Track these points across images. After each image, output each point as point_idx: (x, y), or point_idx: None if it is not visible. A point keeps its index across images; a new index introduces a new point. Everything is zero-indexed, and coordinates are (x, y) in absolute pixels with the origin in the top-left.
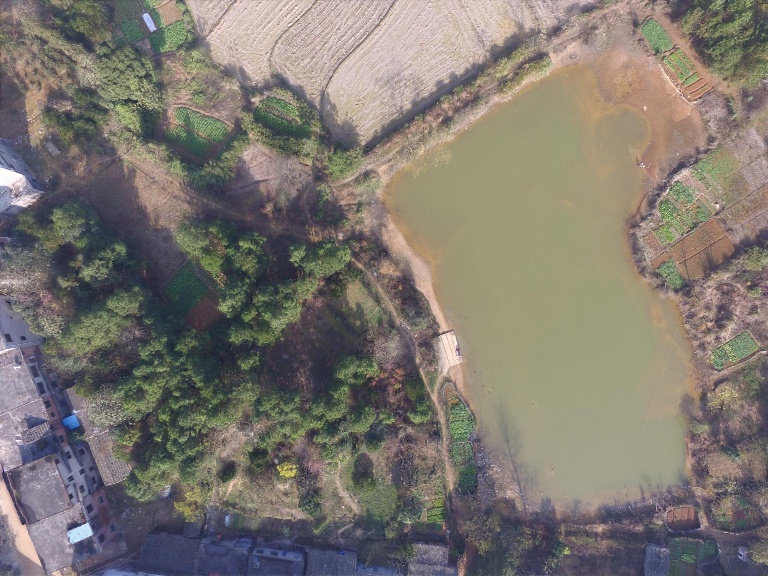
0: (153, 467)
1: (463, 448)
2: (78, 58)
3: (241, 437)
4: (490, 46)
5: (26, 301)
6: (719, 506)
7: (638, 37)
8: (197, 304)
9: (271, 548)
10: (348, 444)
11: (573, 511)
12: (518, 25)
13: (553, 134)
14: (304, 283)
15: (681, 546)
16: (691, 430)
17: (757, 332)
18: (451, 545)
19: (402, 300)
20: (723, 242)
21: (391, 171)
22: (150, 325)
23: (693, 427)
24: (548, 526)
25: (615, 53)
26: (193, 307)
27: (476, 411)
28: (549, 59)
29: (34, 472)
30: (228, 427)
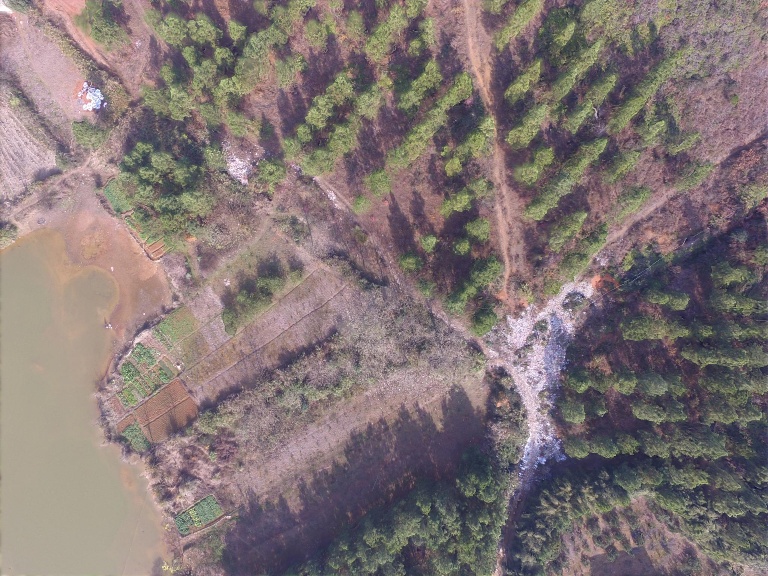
0: None
1: None
2: None
3: None
4: None
5: None
6: None
7: (99, 199)
8: None
9: None
10: None
11: None
12: None
13: (26, 298)
14: None
15: None
16: None
17: (222, 496)
18: None
19: None
20: (187, 403)
21: None
22: None
23: None
24: None
25: (81, 215)
26: None
27: None
28: (3, 230)
29: None
30: None
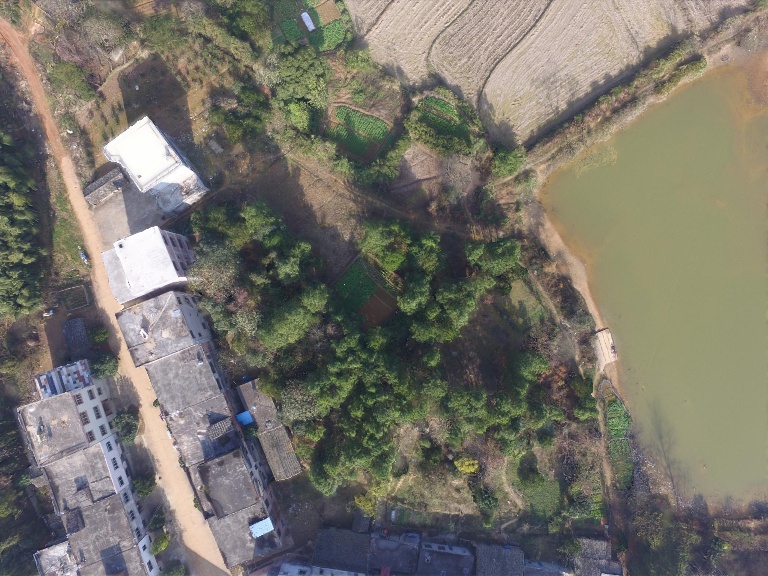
0: (350, 462)
1: (620, 444)
2: (243, 56)
3: (413, 433)
4: (643, 47)
5: (219, 298)
6: None
7: None
8: (367, 301)
9: (436, 543)
10: (526, 440)
11: (724, 506)
12: (671, 27)
13: (704, 135)
14: (484, 281)
15: None
16: None
17: None
18: (613, 540)
19: (562, 298)
20: None
21: (548, 170)
22: (339, 322)
23: None
24: (701, 521)
25: (766, 55)
26: (363, 304)
27: (630, 408)
28: None
29: (222, 467)
30: None
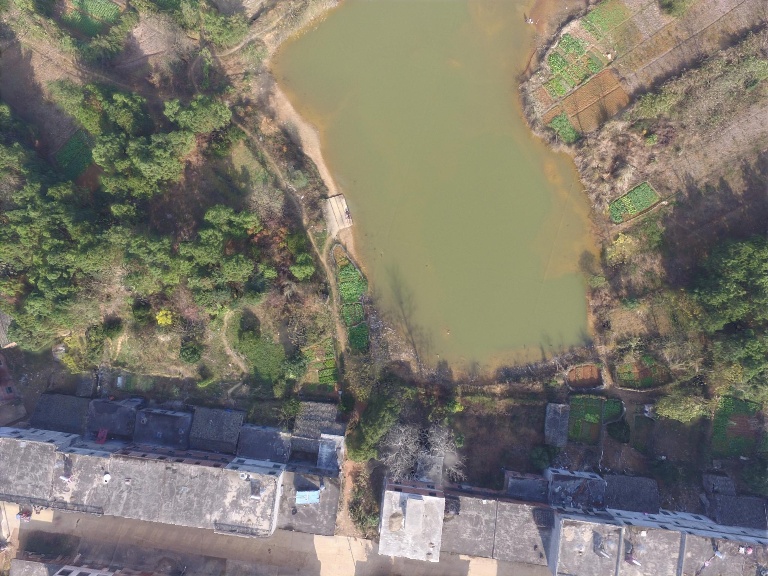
0: None
1: (354, 309)
2: None
3: (126, 294)
4: None
5: None
6: (622, 362)
7: None
8: (85, 170)
9: (163, 409)
10: (224, 291)
11: (471, 373)
12: None
13: None
14: (177, 134)
15: (584, 406)
16: (589, 284)
17: (657, 183)
18: (340, 402)
19: (287, 162)
20: (617, 93)
21: (277, 40)
22: (27, 175)
23: (590, 280)
24: (444, 388)
25: None
26: (82, 173)
27: (368, 274)
28: None
29: None
30: (111, 282)
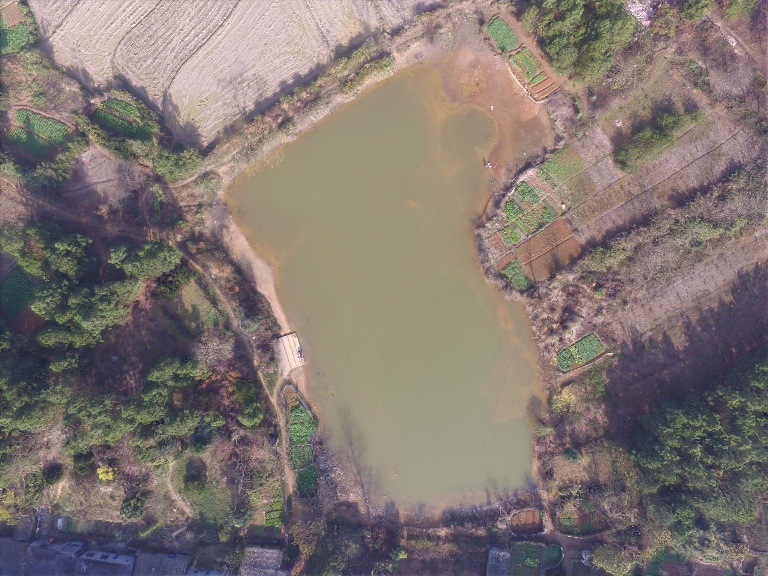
0: None
1: (303, 451)
2: None
3: None
4: (335, 46)
5: None
6: (563, 510)
7: (483, 36)
8: (27, 306)
9: (104, 551)
10: (168, 447)
11: (417, 514)
12: (363, 25)
13: (399, 134)
14: (123, 285)
15: (525, 550)
16: None
17: (604, 334)
18: (285, 549)
19: (239, 302)
20: (570, 243)
21: (233, 172)
22: None
23: (536, 430)
24: (390, 530)
25: (461, 52)
26: (23, 309)
27: (319, 413)
28: (390, 59)
29: None
30: (51, 430)
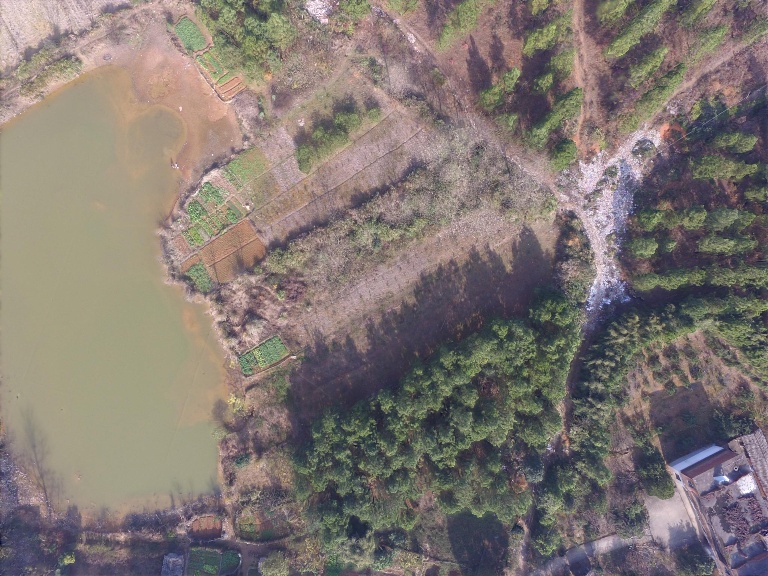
0: None
1: None
2: None
3: None
4: (24, 48)
5: None
6: (240, 516)
7: (170, 37)
8: None
9: None
10: None
11: (100, 519)
12: (53, 27)
13: (88, 136)
14: None
15: (205, 556)
16: None
17: (288, 337)
18: None
19: None
20: (254, 244)
21: None
22: None
23: (212, 434)
24: (69, 534)
25: (150, 53)
26: None
27: (2, 416)
28: (69, 60)
29: None
30: None
